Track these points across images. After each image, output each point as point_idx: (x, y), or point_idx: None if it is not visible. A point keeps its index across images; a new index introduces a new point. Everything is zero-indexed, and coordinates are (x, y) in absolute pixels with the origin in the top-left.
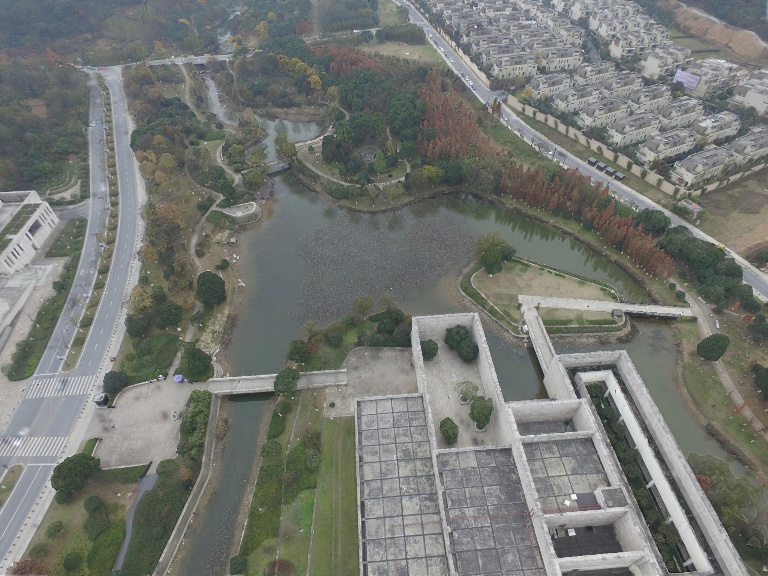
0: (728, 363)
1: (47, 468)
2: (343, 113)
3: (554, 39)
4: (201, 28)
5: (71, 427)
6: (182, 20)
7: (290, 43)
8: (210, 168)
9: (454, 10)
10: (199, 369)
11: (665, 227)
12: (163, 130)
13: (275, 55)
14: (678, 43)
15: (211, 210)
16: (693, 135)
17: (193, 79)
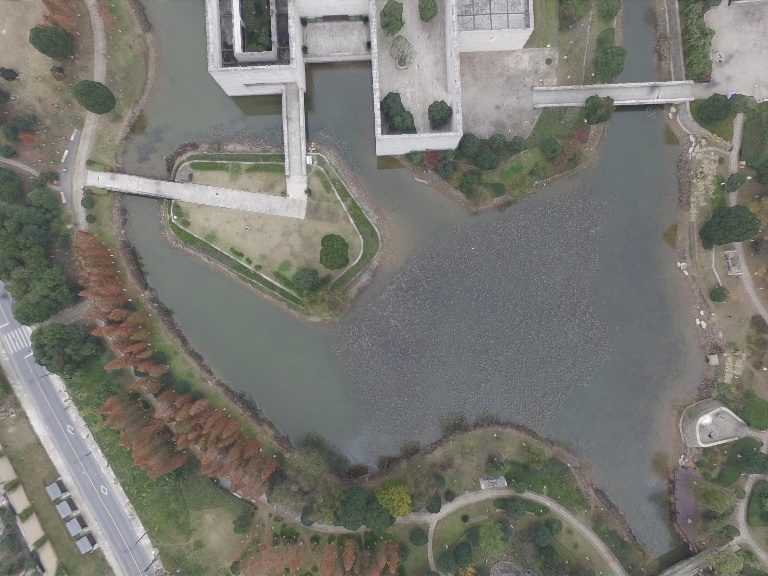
0: None
1: None
2: None
3: None
4: None
5: None
6: None
7: None
8: None
9: None
10: None
11: None
12: None
13: None
14: None
15: None
16: None
17: None
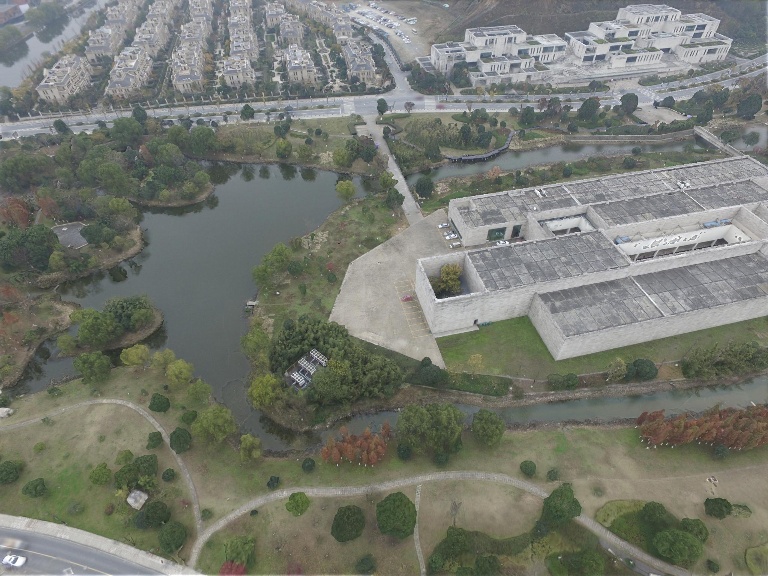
0: None
1: (619, 103)
2: None
3: None
4: None
5: (638, 102)
6: None
7: None
8: None
9: None
10: (702, 117)
11: None
12: None
13: None
14: None
15: None
16: None
17: None
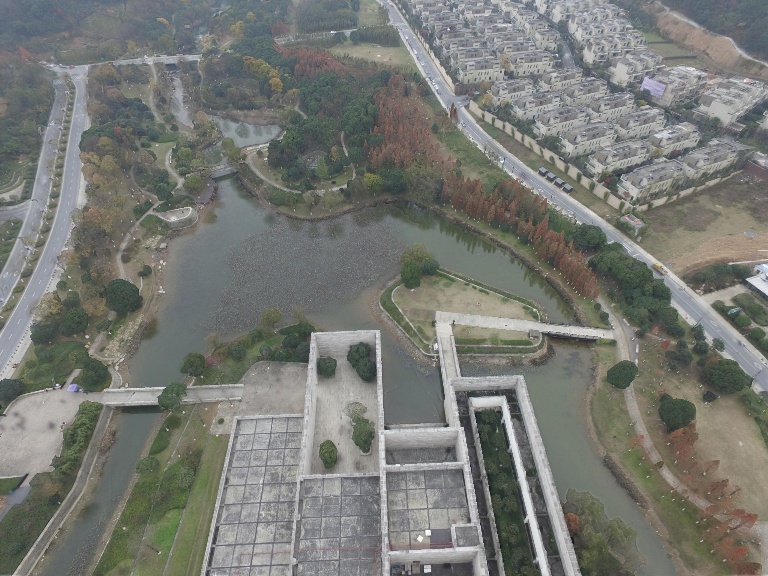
0: (640, 391)
1: None
2: (300, 117)
3: (526, 43)
4: (178, 27)
5: None
6: (160, 19)
7: (259, 44)
8: (153, 171)
9: (432, 11)
10: (92, 379)
11: (600, 244)
12: (111, 132)
13: (241, 56)
14: (655, 48)
15: (147, 214)
16: (645, 147)
17: (161, 79)
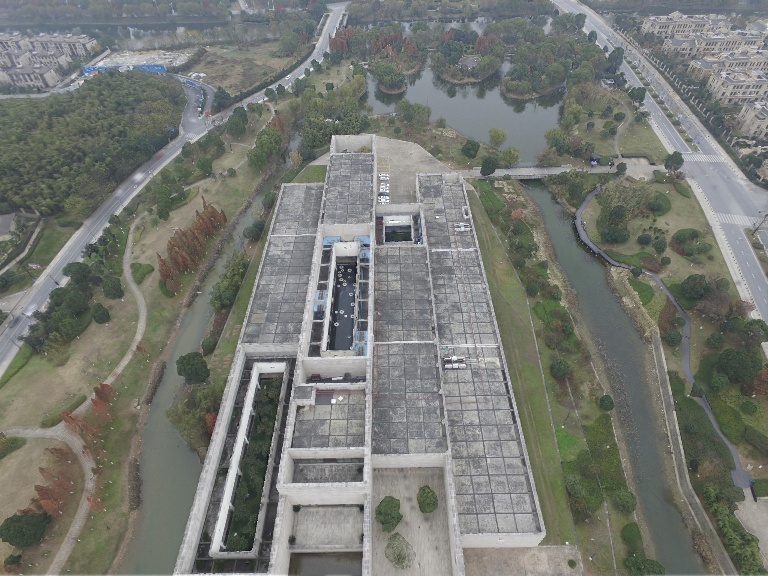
0: None
1: None
2: None
3: None
4: None
5: None
6: None
7: None
8: None
9: None
10: None
11: None
12: None
13: None
14: None
15: None
16: None
17: None
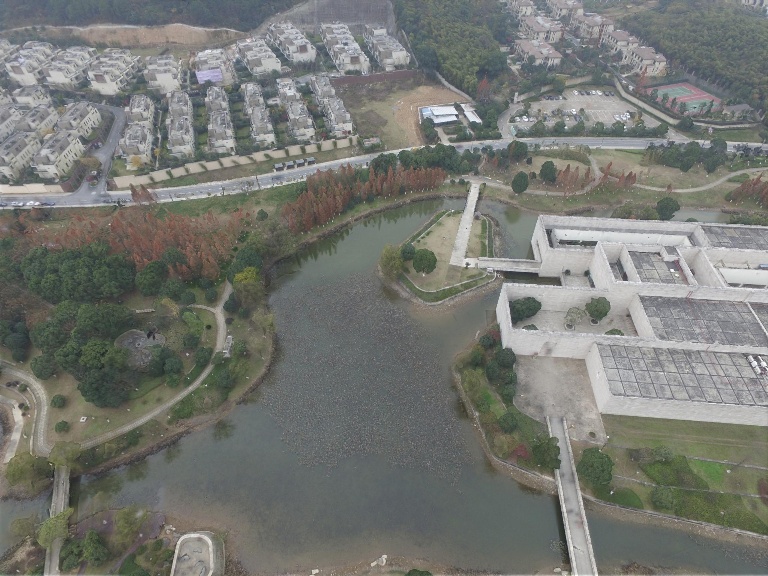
0: None
1: None
2: None
3: (36, 109)
4: None
5: None
6: None
7: None
8: None
9: None
10: None
11: None
12: None
13: None
14: None
15: None
16: (303, 103)
17: None
